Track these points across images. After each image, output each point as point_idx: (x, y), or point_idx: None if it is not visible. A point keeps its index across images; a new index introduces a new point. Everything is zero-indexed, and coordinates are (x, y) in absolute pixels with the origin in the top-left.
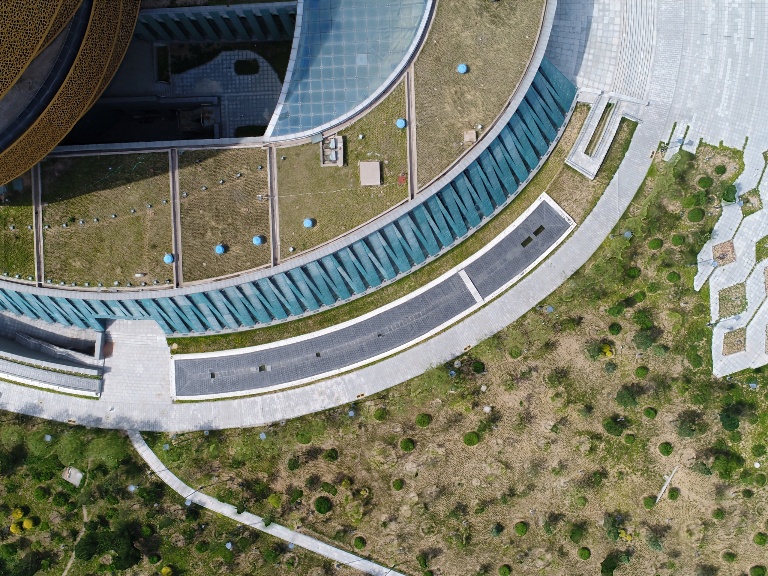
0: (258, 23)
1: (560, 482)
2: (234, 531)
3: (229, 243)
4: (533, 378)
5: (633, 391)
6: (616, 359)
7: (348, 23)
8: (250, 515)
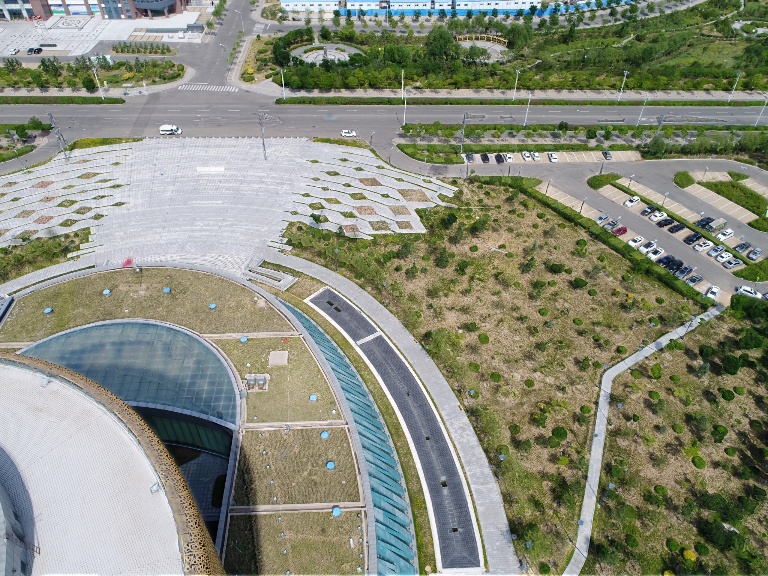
0: None
1: (506, 295)
2: (606, 511)
3: (325, 461)
4: (435, 307)
5: None
6: None
7: (156, 371)
8: (586, 496)
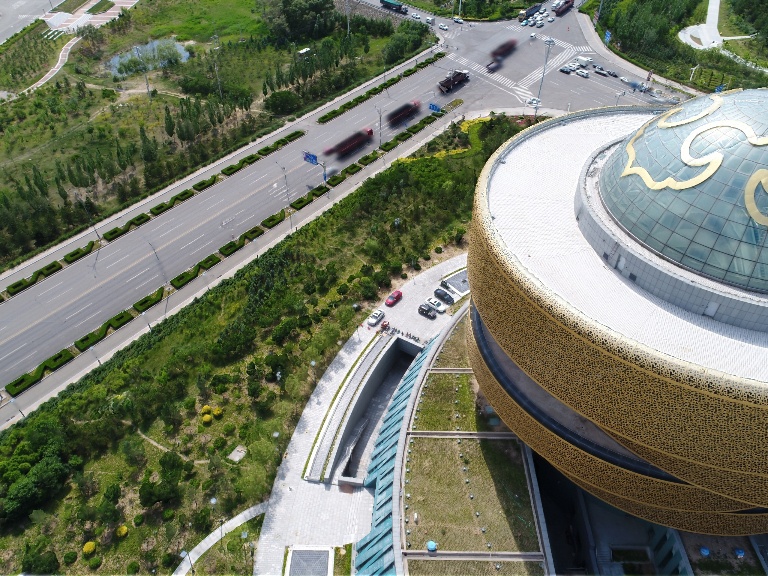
0: None
1: None
2: None
3: None
4: None
5: None
6: None
7: None
8: None
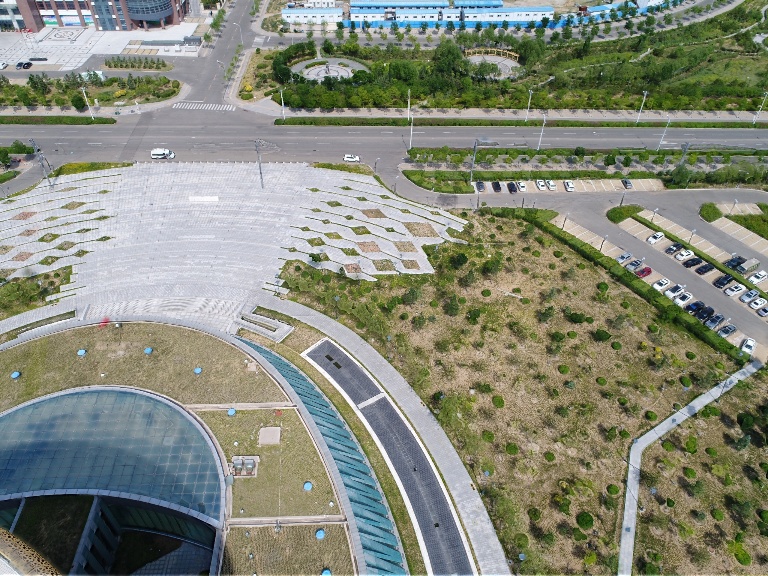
0: (95, 558)
1: (522, 349)
2: None
3: (320, 568)
4: (444, 363)
5: (448, 309)
6: (426, 316)
7: (132, 452)
8: None
